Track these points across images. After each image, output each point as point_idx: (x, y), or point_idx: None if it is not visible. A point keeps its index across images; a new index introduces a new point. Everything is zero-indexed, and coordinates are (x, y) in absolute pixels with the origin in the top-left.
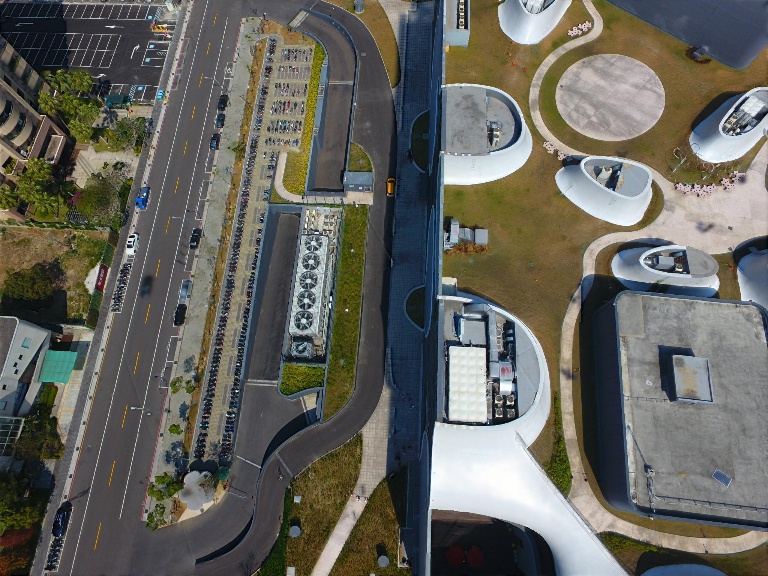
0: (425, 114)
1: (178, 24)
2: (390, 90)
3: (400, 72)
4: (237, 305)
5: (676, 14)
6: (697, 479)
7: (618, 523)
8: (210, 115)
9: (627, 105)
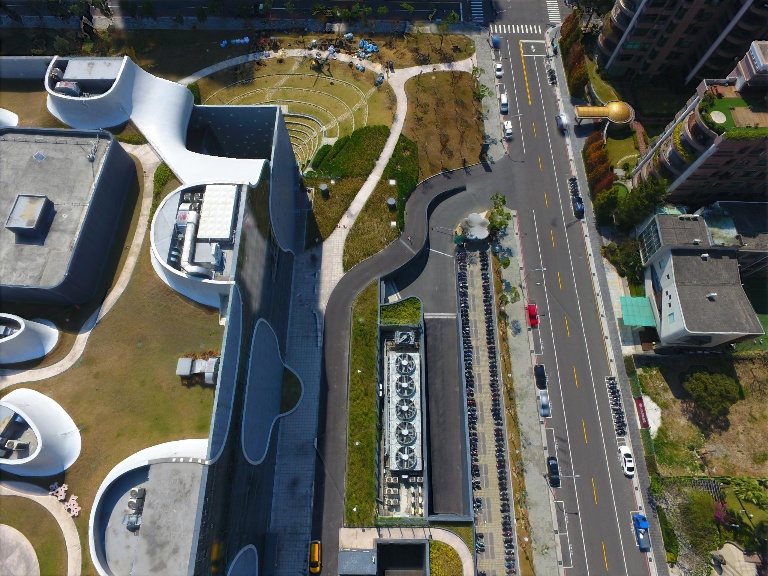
0: None
1: None
2: None
3: None
4: (484, 391)
5: None
6: (58, 156)
7: (130, 150)
8: None
9: None
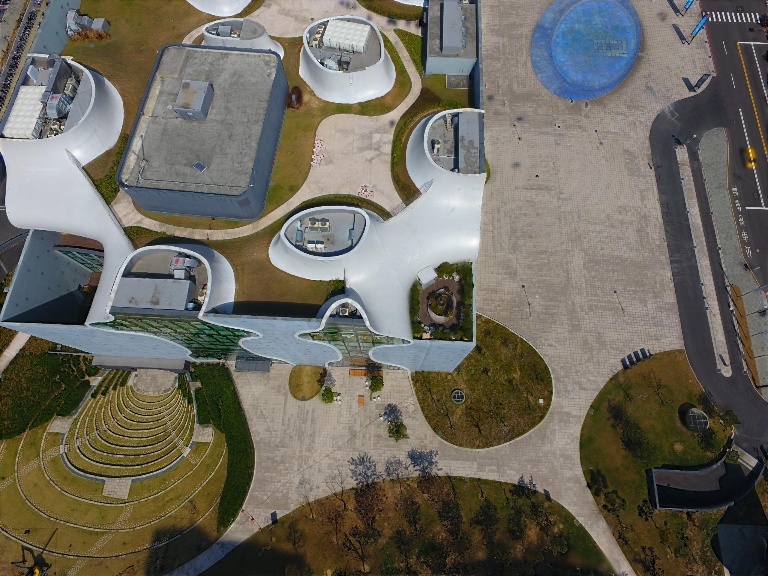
0: None
1: None
2: None
3: None
4: None
5: None
6: (180, 168)
7: (144, 220)
8: None
9: None
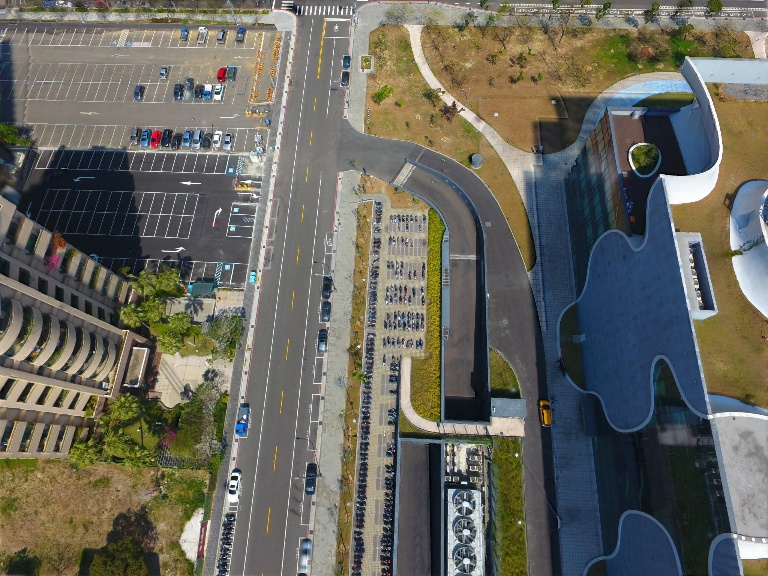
0: (572, 308)
1: (264, 180)
2: (526, 274)
3: (534, 249)
4: (370, 575)
5: None
6: None
7: None
8: (313, 304)
9: None
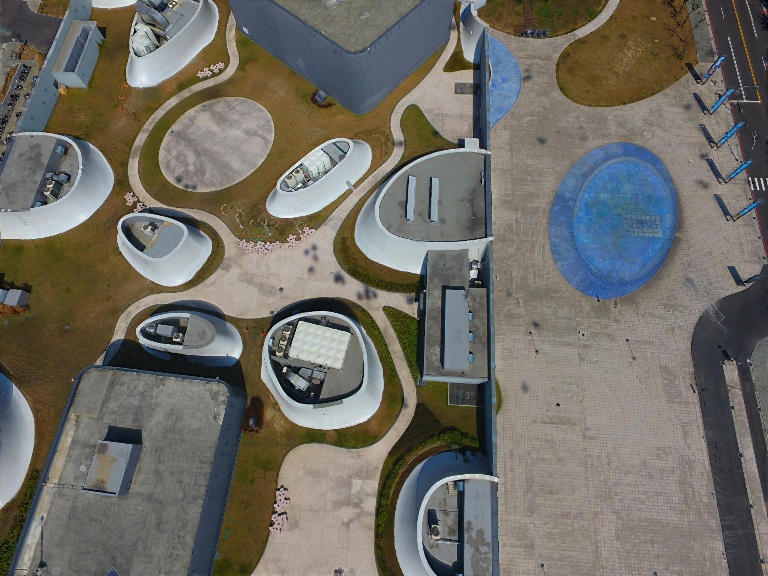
0: None
1: None
2: None
3: None
4: None
5: (294, 57)
6: None
7: None
8: None
9: (230, 153)
